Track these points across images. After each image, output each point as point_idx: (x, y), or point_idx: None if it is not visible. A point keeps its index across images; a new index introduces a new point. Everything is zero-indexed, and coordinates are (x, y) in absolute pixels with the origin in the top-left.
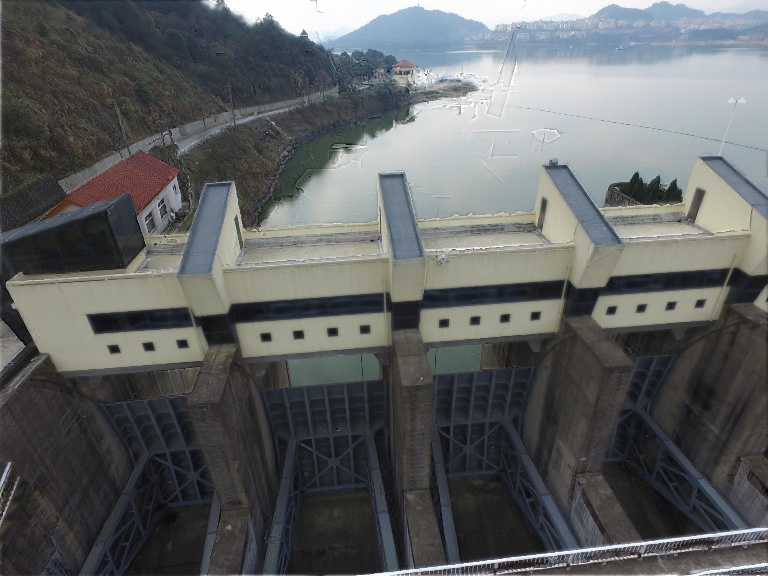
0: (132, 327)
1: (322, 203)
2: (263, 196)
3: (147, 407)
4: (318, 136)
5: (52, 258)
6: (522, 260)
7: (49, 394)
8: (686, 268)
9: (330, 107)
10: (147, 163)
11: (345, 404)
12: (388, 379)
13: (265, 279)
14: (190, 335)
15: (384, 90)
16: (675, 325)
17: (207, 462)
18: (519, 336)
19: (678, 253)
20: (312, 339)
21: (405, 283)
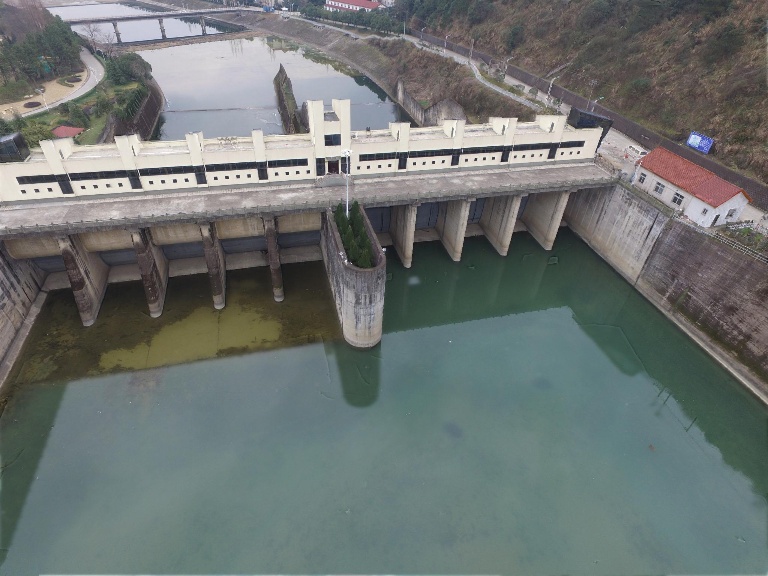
0: None
1: None
2: None
3: None
4: None
5: None
6: (465, 129)
7: None
8: None
9: None
10: (719, 188)
11: None
12: None
13: None
14: None
15: None
16: None
17: None
18: None
19: None
20: None
21: None
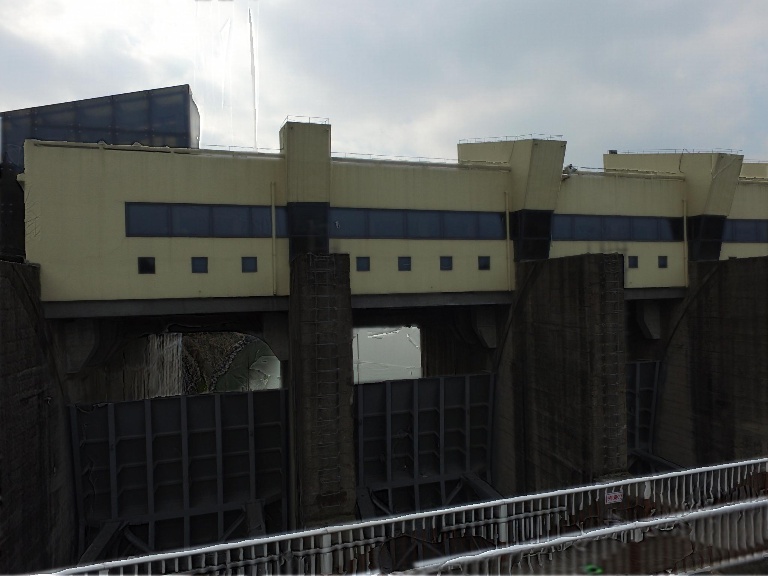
0: (184, 231)
1: None
2: (219, 369)
3: (147, 413)
4: None
5: (94, 140)
6: (640, 187)
7: (22, 317)
8: None
9: None
10: None
11: (439, 417)
12: (495, 372)
13: (373, 176)
14: (263, 251)
15: None
16: None
17: (304, 388)
18: (649, 291)
19: None
20: (420, 272)
21: (541, 178)
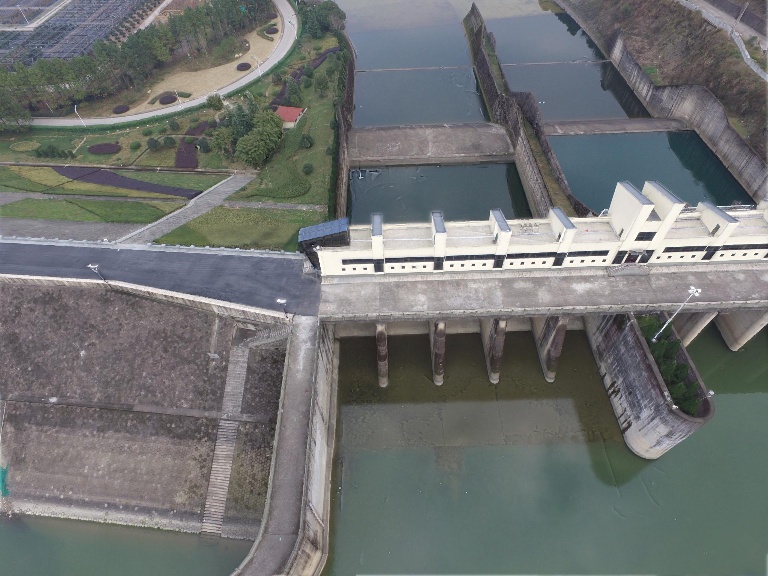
0: None
1: None
2: None
3: None
4: None
5: None
6: None
7: None
8: None
9: None
10: None
11: None
12: None
13: None
14: None
15: None
16: None
17: None
18: None
19: None
20: None
21: None
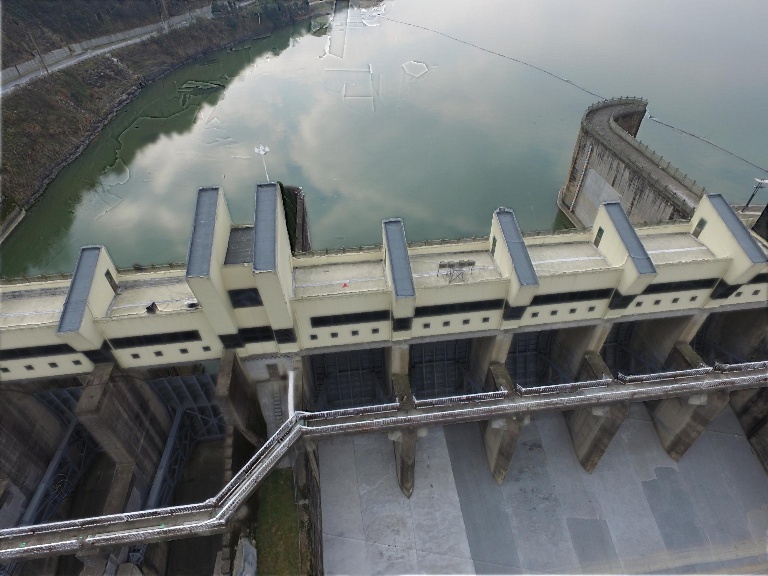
0: None
1: (126, 164)
2: (64, 158)
3: None
4: (181, 68)
5: None
6: None
7: None
8: (39, 344)
9: (198, 32)
10: None
11: None
12: None
13: None
14: None
15: (272, 5)
16: (75, 374)
17: None
18: None
19: (21, 337)
20: None
21: None
